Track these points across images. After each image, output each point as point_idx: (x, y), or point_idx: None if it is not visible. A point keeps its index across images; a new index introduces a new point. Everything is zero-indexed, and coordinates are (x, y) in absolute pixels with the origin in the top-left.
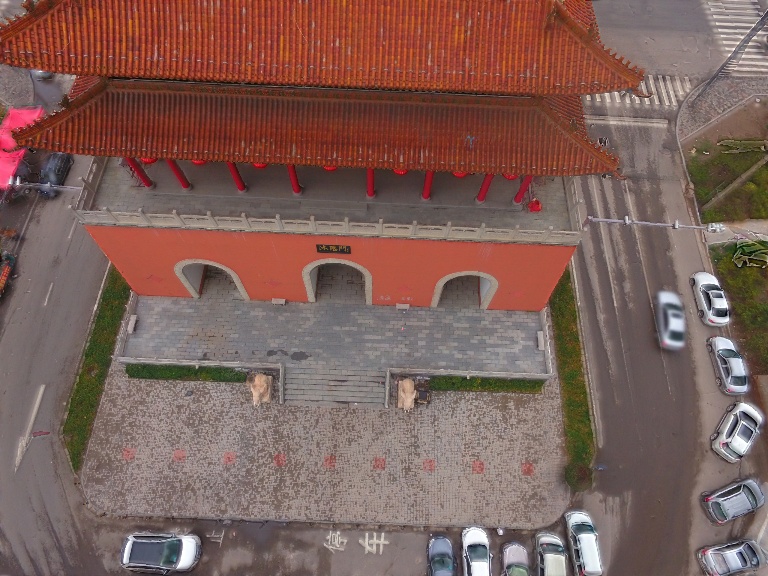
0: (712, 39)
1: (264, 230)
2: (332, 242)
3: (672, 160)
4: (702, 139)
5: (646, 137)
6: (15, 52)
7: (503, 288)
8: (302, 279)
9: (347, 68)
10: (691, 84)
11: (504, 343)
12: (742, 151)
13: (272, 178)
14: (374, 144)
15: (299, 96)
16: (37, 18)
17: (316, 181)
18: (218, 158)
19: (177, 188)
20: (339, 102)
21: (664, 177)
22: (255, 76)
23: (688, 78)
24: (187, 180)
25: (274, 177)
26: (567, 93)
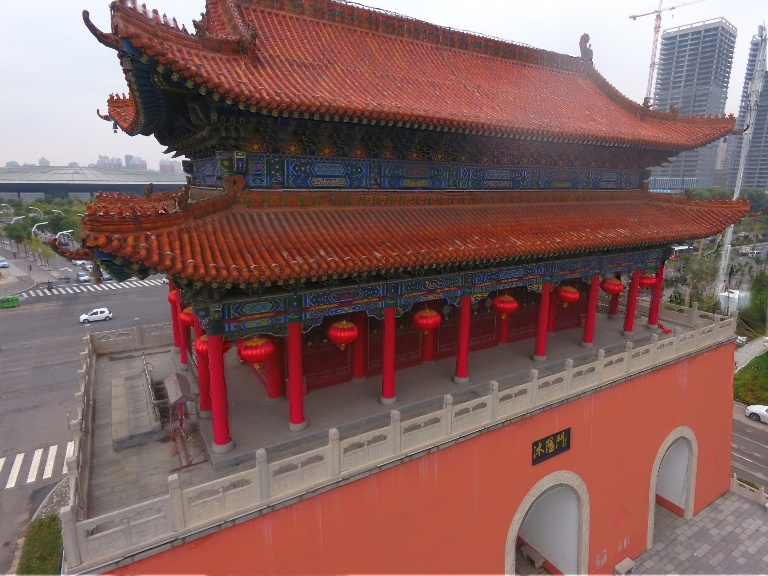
0: None
1: (472, 430)
2: (550, 428)
3: None
4: None
5: None
6: (178, 55)
7: (700, 454)
8: (502, 570)
9: (558, 125)
10: None
11: (764, 541)
12: None
13: (411, 382)
14: None
15: (477, 204)
16: (203, 50)
17: None
18: (443, 257)
19: (278, 434)
20: (514, 207)
21: None
22: (492, 122)
23: None
24: None
25: (412, 380)
26: (697, 142)
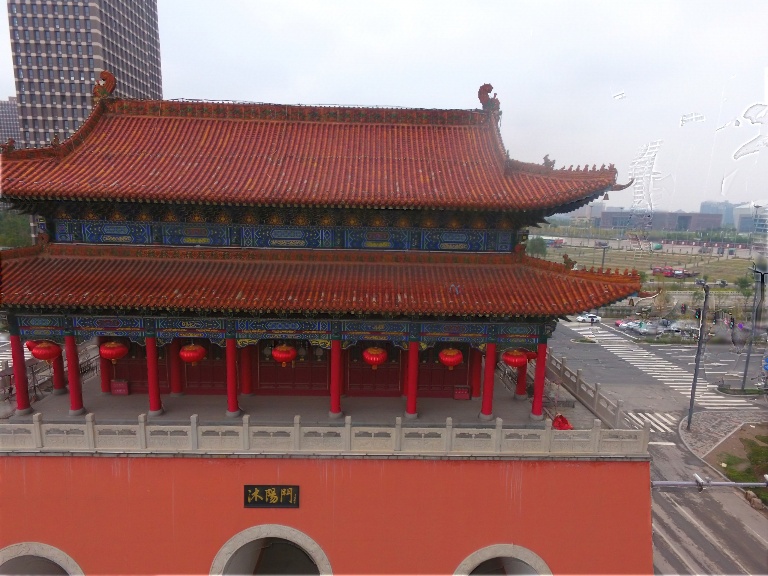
0: (669, 391)
1: (166, 451)
2: (271, 478)
3: (707, 475)
4: (724, 456)
5: (661, 456)
6: None
7: None
8: None
9: (313, 191)
10: (675, 418)
11: None
12: (765, 108)
13: (202, 406)
14: (340, 291)
15: (258, 259)
16: (8, 160)
17: (262, 406)
18: (137, 301)
19: (61, 414)
20: (302, 264)
21: (711, 490)
22: (213, 194)
23: (668, 414)
24: (82, 399)
25: (206, 405)
26: (546, 201)
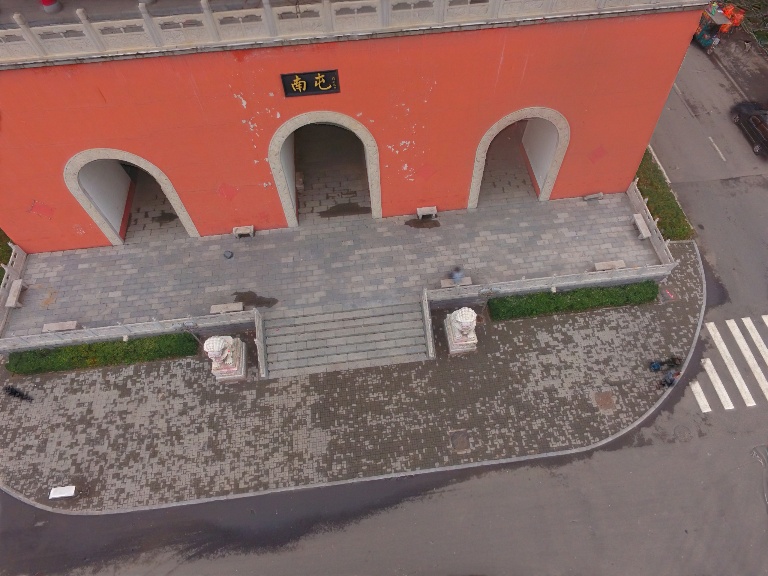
0: None
1: None
2: None
3: None
4: None
5: None
6: None
7: None
8: None
9: None
10: None
11: None
12: None
13: None
14: None
15: None
16: None
17: None
18: None
19: None
20: None
21: None
22: None
23: None
24: None
25: None
26: None
